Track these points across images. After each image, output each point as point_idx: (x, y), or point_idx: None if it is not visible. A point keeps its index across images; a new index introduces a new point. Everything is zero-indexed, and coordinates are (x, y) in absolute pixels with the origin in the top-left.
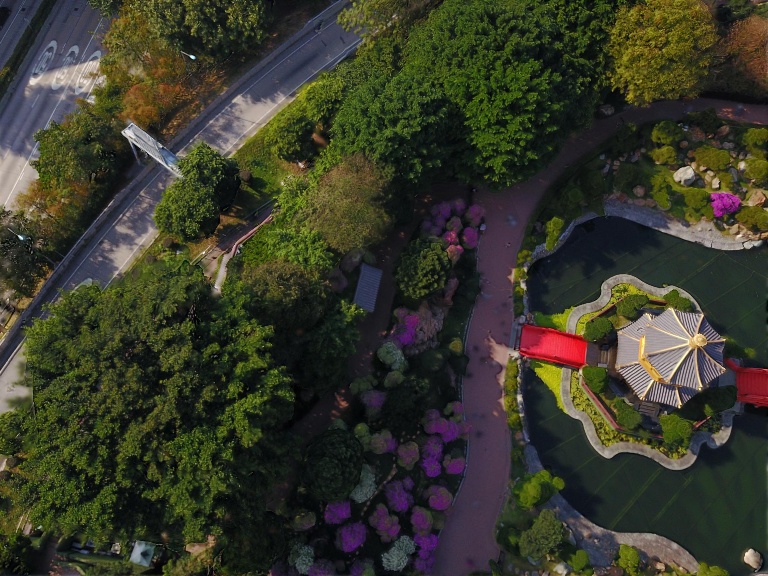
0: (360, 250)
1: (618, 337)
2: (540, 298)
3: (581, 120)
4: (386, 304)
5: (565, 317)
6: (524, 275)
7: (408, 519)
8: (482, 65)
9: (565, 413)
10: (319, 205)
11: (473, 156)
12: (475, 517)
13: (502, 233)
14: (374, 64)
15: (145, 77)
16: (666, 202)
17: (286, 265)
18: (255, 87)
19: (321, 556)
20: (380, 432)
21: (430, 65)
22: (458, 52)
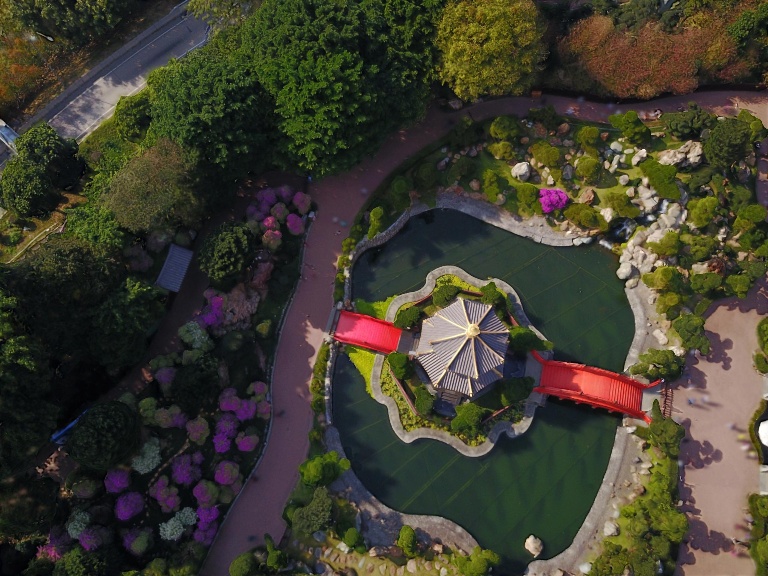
0: (166, 231)
1: (423, 326)
2: (366, 286)
3: (408, 112)
4: (204, 285)
5: (386, 305)
6: (347, 262)
7: (191, 491)
8: (292, 55)
9: (372, 398)
10: (111, 185)
11: (287, 144)
12: (268, 493)
13: (332, 221)
14: (220, 51)
15: (1, 57)
16: (495, 196)
17: (74, 242)
18: (117, 70)
19: (104, 523)
20: (169, 407)
21: (250, 53)
22: (272, 41)
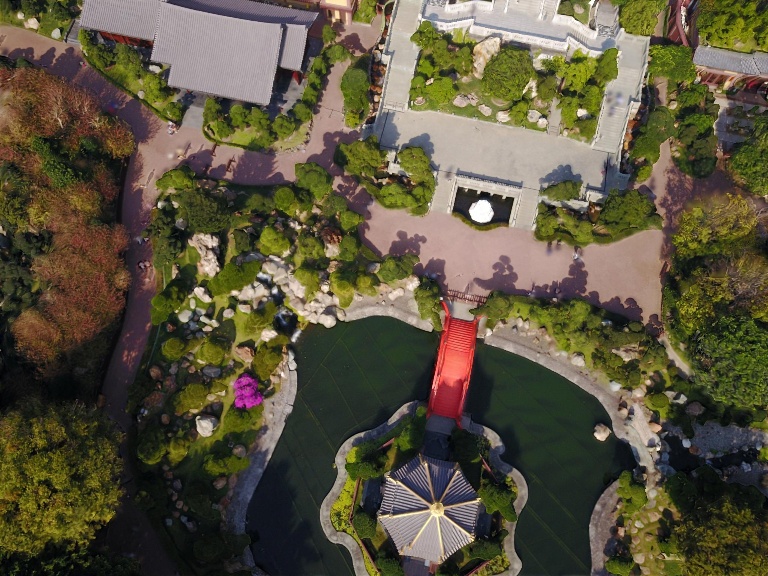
0: None
1: (406, 555)
2: None
3: None
4: None
5: None
6: None
7: None
8: None
9: None
10: None
11: None
12: None
13: None
14: None
15: None
16: (242, 461)
17: None
18: None
19: None
20: None
21: None
22: None
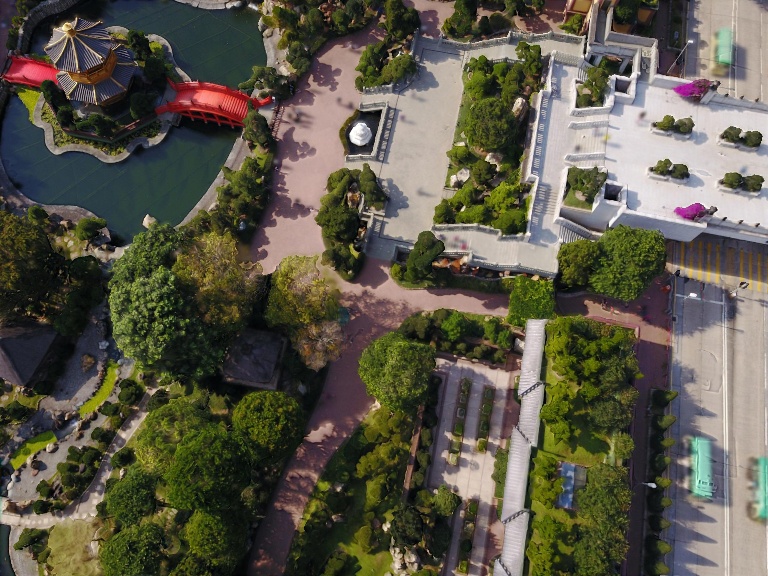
0: None
1: None
2: (42, 44)
3: None
4: None
5: None
6: (21, 21)
7: None
8: None
9: (33, 124)
10: None
11: None
12: None
13: None
14: None
15: None
16: None
17: None
18: None
19: None
20: None
21: None
22: None
